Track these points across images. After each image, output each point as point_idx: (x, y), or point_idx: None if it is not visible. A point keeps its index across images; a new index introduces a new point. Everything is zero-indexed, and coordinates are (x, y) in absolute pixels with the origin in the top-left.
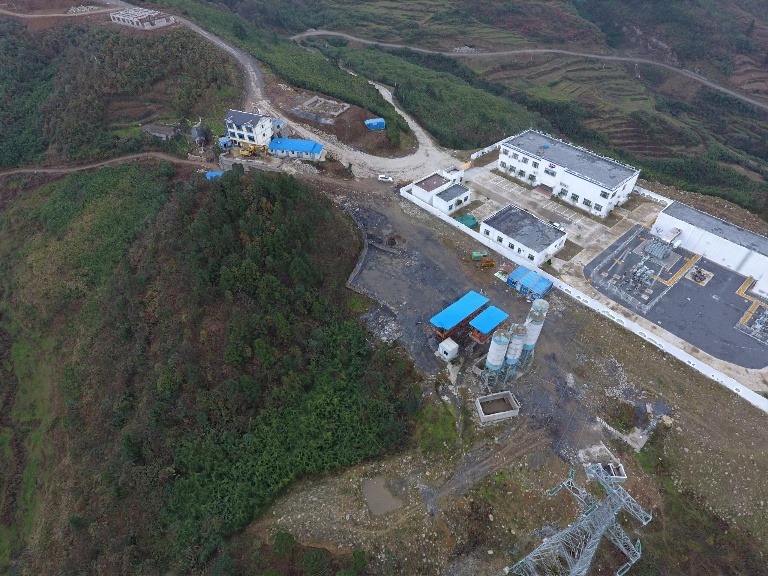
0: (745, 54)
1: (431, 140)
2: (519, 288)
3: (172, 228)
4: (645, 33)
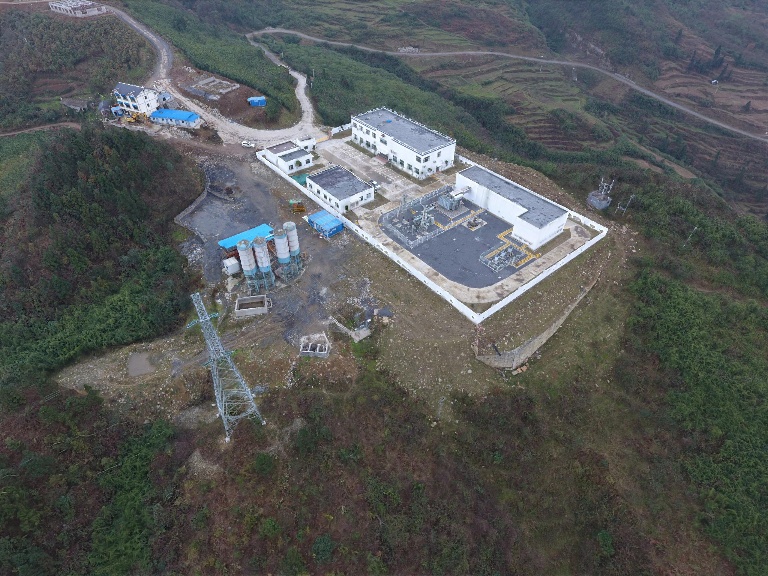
0: (672, 61)
1: (313, 118)
2: (316, 227)
3: (34, 170)
4: (585, 39)
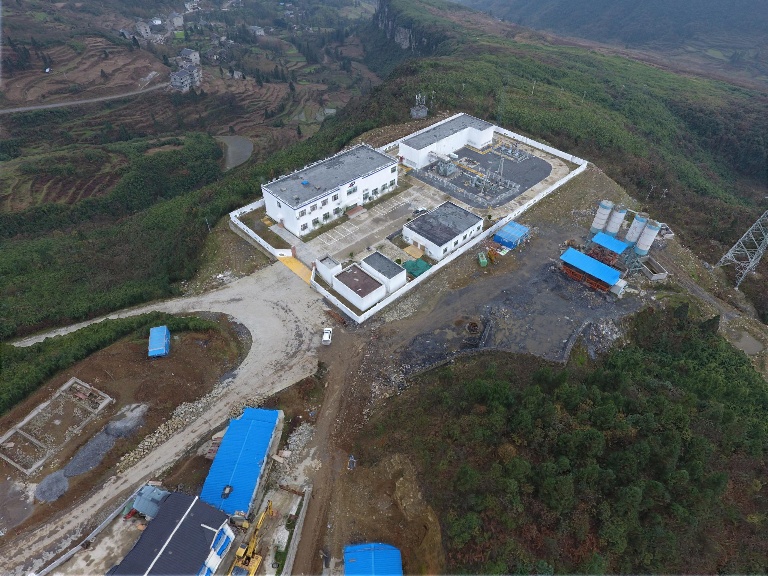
0: None
1: (172, 300)
2: None
3: None
4: None
